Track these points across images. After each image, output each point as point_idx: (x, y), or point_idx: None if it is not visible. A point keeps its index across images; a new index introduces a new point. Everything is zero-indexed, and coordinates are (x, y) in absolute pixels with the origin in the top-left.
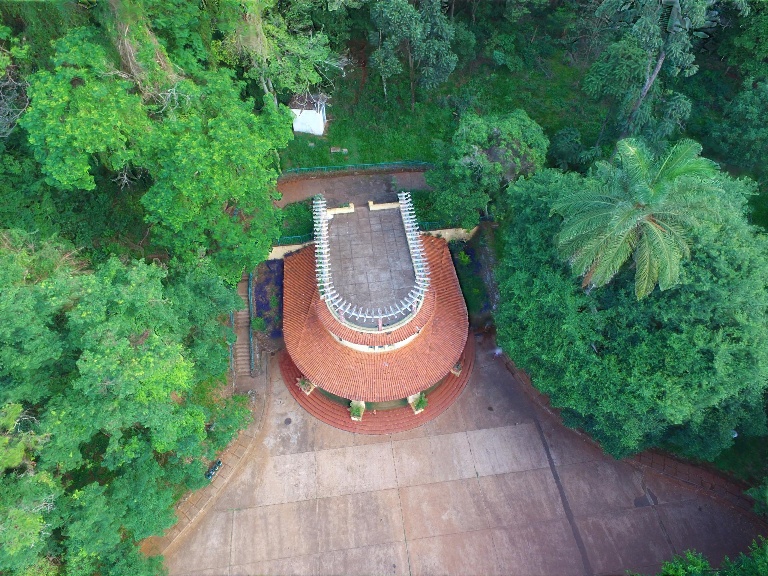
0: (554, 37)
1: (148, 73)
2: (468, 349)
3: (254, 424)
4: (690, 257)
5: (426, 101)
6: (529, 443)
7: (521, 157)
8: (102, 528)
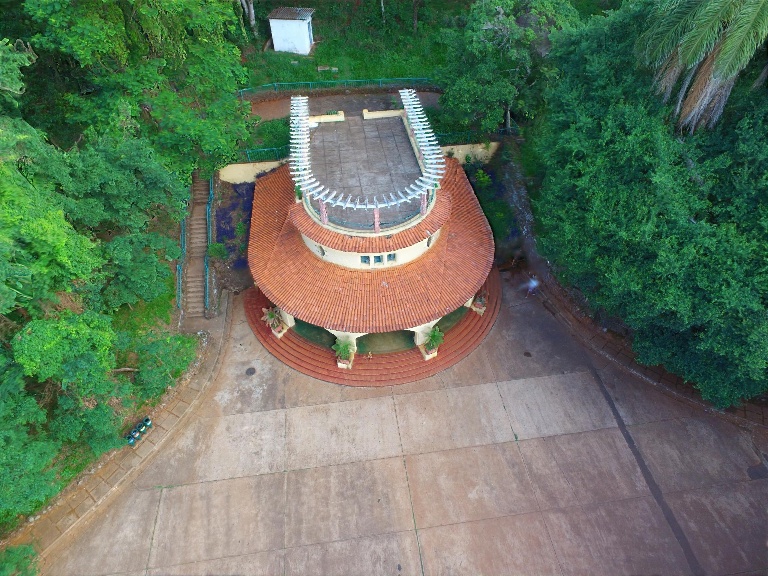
0: None
1: None
2: (492, 285)
3: (203, 374)
4: None
5: (430, 22)
6: (585, 396)
7: None
8: None
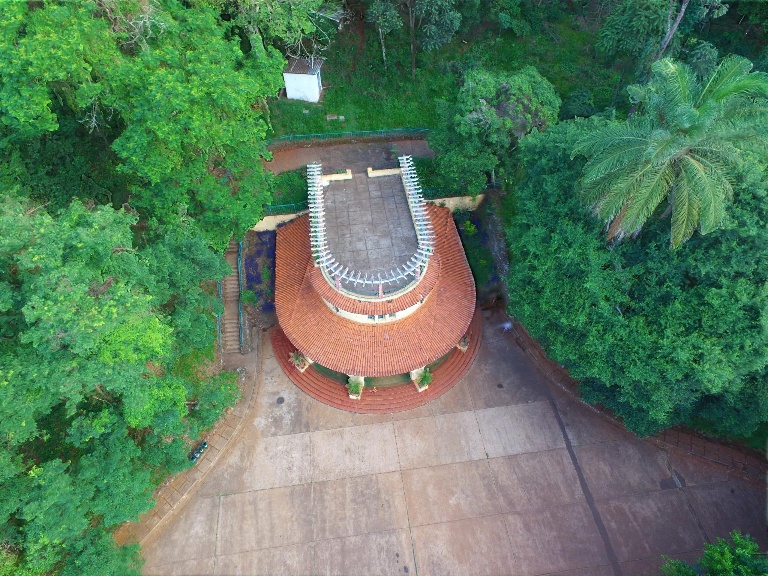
0: (562, 1)
1: (119, 1)
2: (475, 324)
3: (243, 403)
4: (733, 199)
5: (427, 67)
6: (543, 422)
7: (532, 114)
8: (67, 512)
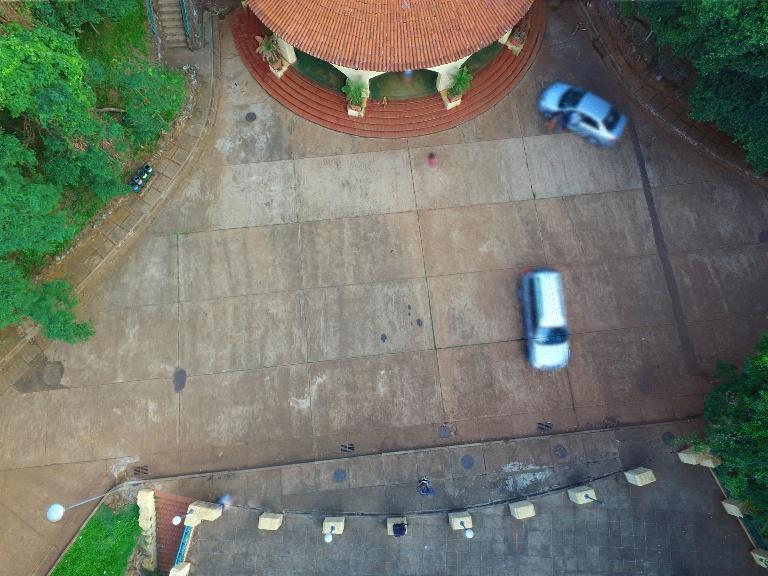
0: None
1: None
2: (536, 14)
3: (198, 119)
4: None
5: None
6: (616, 155)
7: None
8: None
